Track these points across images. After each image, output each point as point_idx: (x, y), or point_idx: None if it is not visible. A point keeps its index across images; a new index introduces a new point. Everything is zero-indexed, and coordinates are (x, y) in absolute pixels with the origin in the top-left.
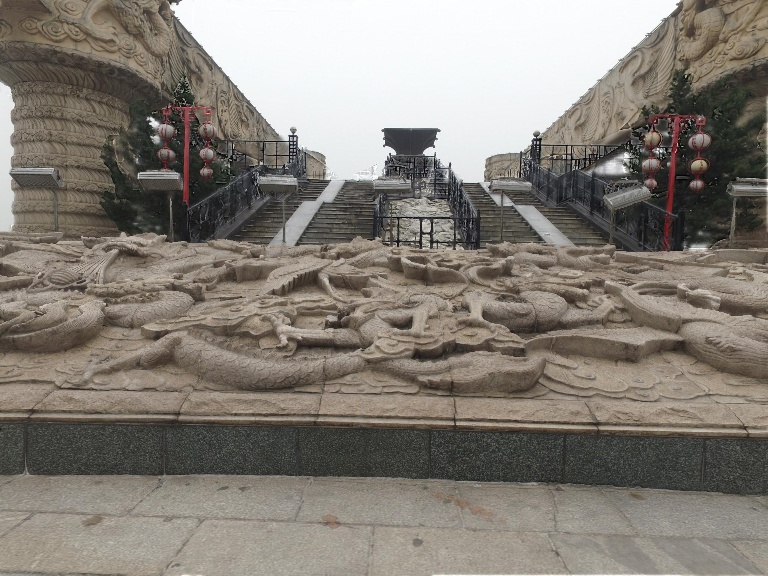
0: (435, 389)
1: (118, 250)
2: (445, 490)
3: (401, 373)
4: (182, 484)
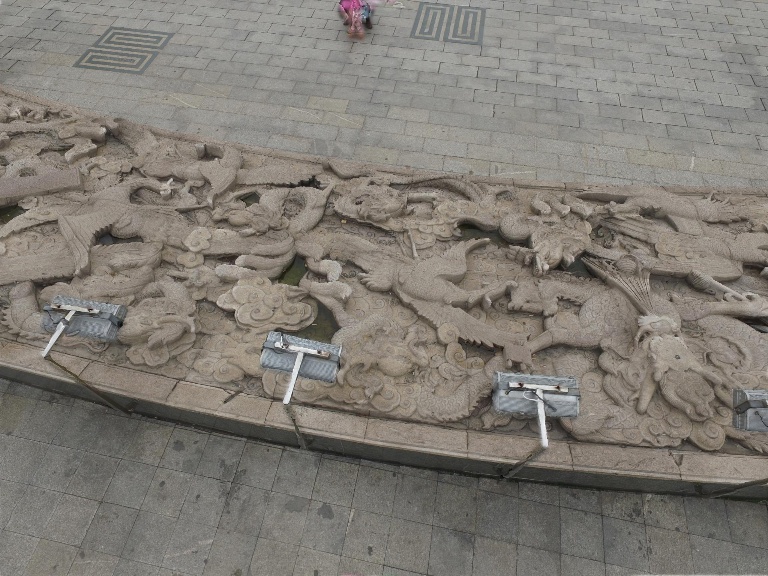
0: None
1: None
2: None
3: None
4: None
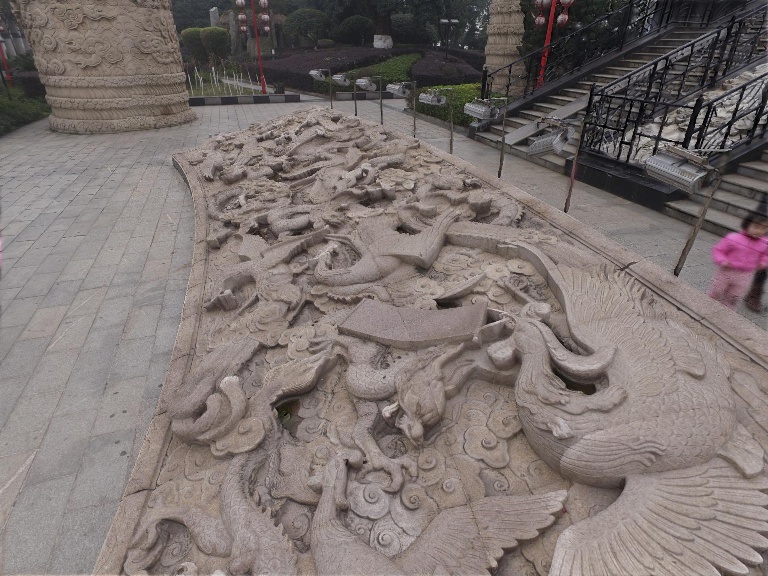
0: None
1: (316, 134)
2: None
3: None
4: None
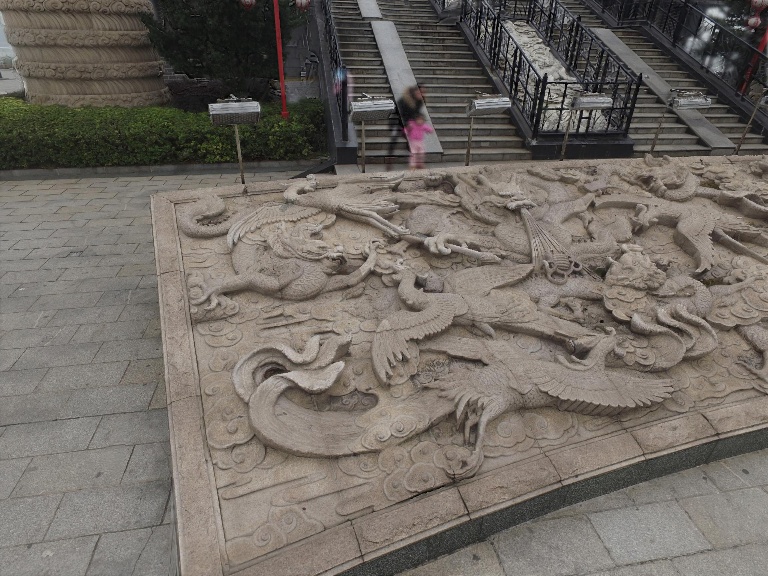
0: None
1: None
2: None
3: None
4: None
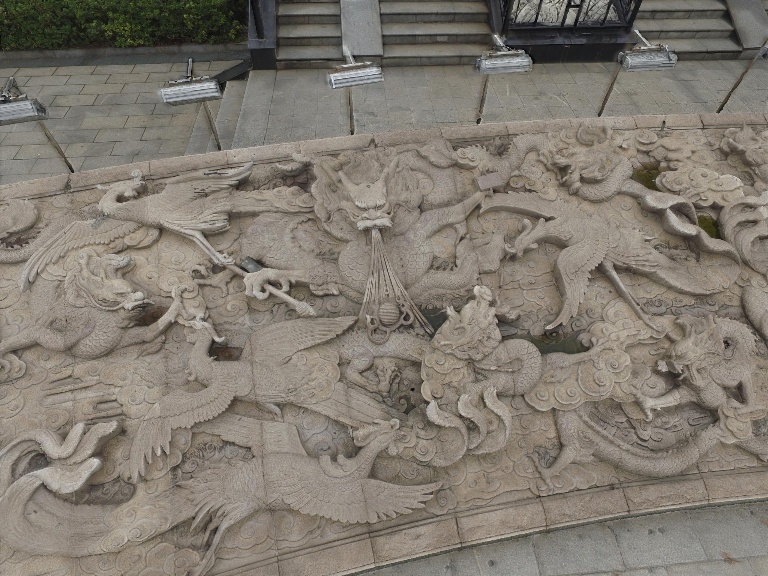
0: (767, 461)
1: (379, 231)
2: (762, 513)
3: (746, 450)
4: (625, 530)
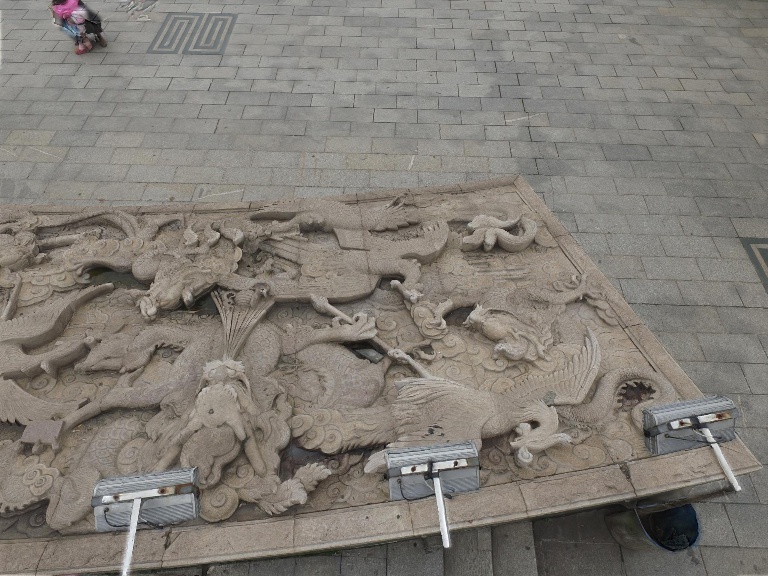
0: None
1: None
2: None
3: None
4: None
